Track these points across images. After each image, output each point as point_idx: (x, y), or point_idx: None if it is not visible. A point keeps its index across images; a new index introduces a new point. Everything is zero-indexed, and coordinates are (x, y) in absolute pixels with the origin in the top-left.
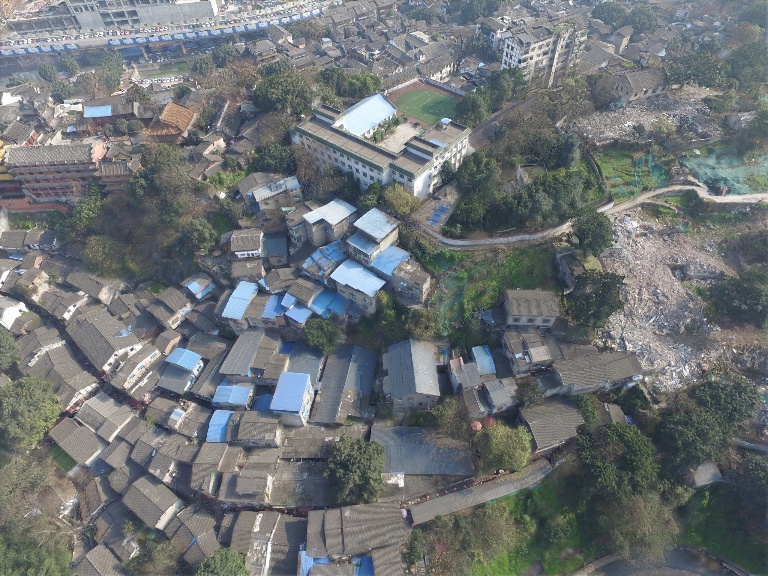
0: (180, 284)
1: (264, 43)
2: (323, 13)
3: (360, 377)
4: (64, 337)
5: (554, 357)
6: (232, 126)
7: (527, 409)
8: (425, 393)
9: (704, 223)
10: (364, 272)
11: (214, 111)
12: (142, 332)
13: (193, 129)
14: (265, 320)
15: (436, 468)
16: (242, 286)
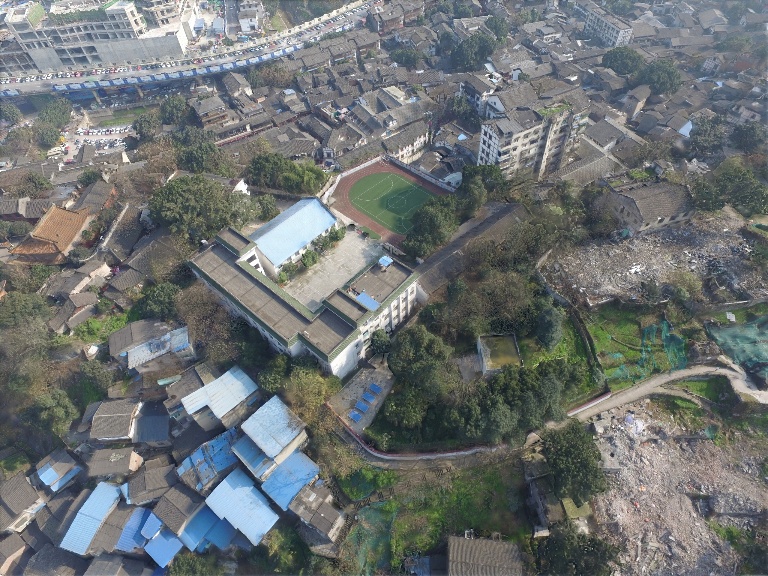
0: (39, 461)
1: (210, 101)
2: (294, 54)
3: None
4: None
5: None
6: (126, 242)
7: None
8: None
9: (740, 426)
10: (252, 496)
11: (113, 214)
12: None
13: (81, 241)
14: None
15: None
16: (99, 492)
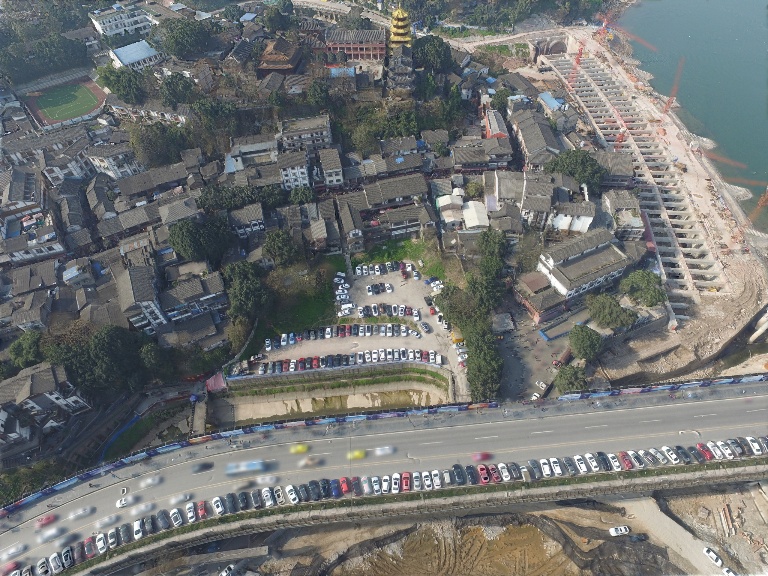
0: None
1: None
2: None
3: None
4: None
5: None
6: None
7: None
8: None
9: None
10: None
11: None
12: None
13: None
14: None
15: None
16: None
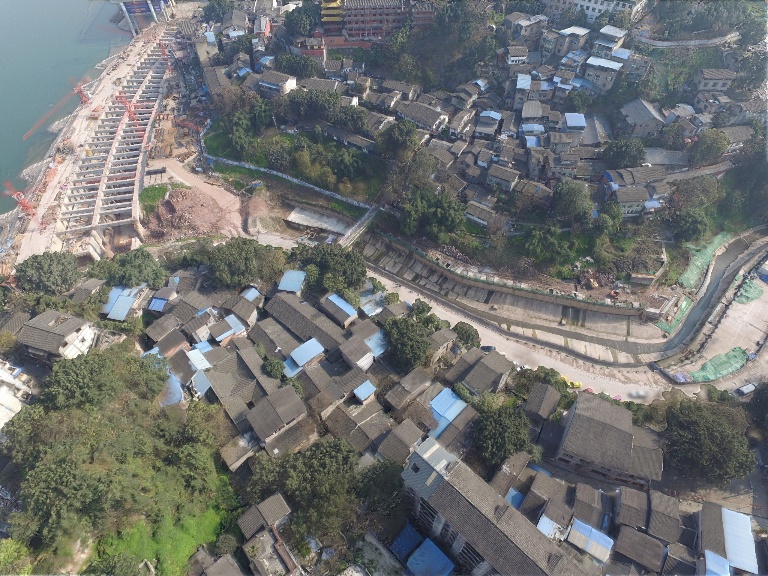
0: None
1: None
2: None
3: (603, 127)
4: (393, 116)
5: (732, 103)
6: None
7: (719, 128)
8: (659, 119)
9: None
10: (607, 60)
11: None
12: (449, 109)
13: None
14: (541, 93)
15: (667, 161)
16: (521, 75)
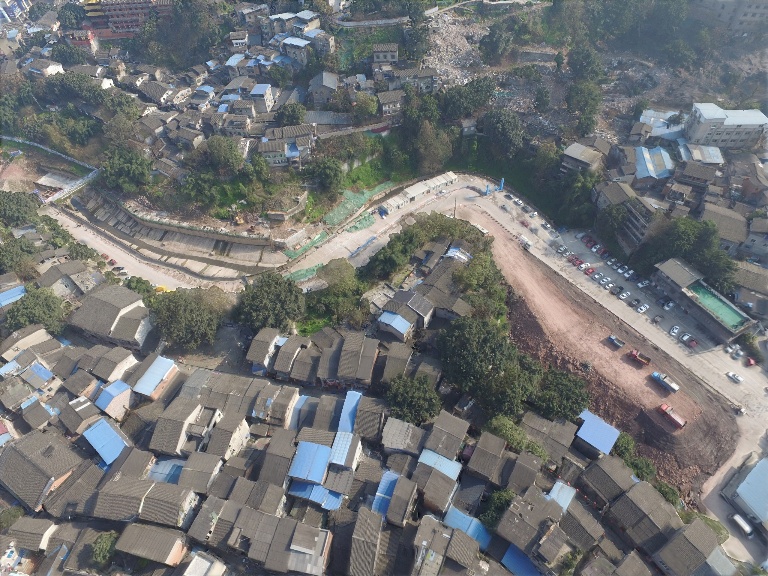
0: None
1: None
2: None
3: (299, 96)
4: (137, 93)
5: None
6: None
7: None
8: (328, 86)
9: (487, 18)
10: (300, 39)
11: None
12: (181, 86)
13: None
14: (248, 69)
15: (333, 121)
16: (236, 55)
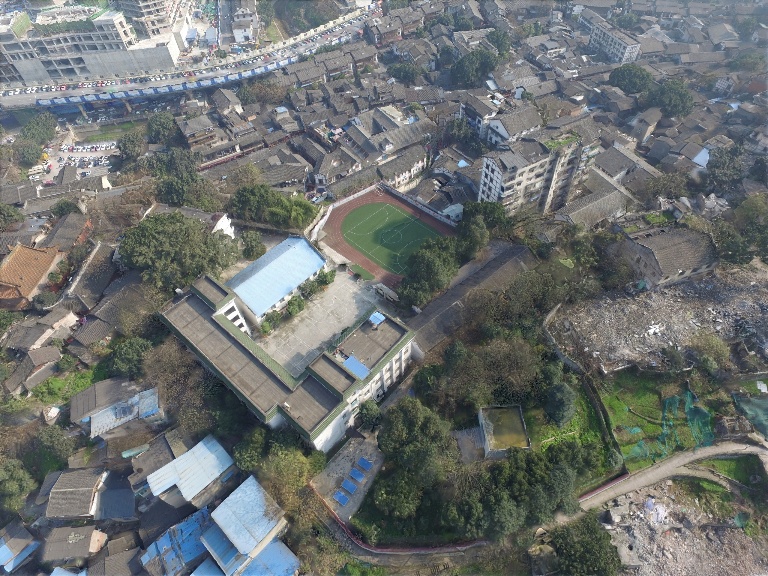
0: None
1: (197, 121)
2: (287, 69)
3: None
4: None
5: None
6: (95, 286)
7: None
8: None
9: None
10: None
11: (85, 251)
12: None
13: (49, 283)
14: None
15: None
16: None
